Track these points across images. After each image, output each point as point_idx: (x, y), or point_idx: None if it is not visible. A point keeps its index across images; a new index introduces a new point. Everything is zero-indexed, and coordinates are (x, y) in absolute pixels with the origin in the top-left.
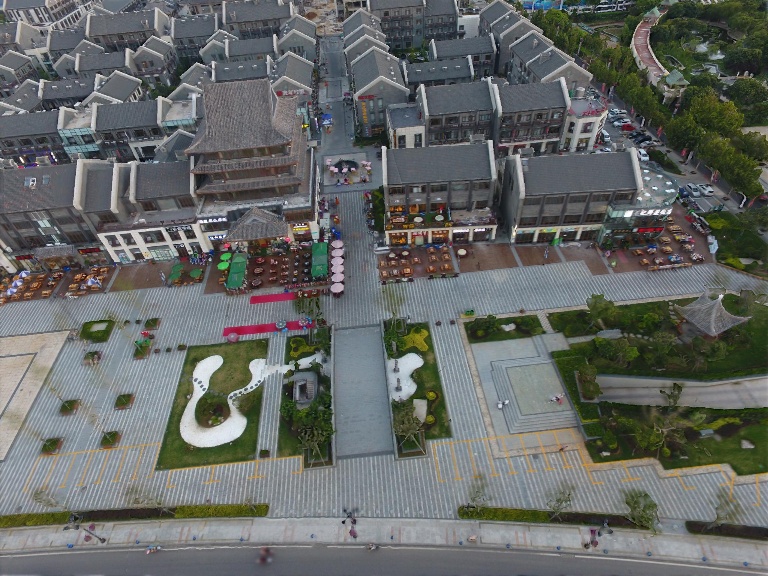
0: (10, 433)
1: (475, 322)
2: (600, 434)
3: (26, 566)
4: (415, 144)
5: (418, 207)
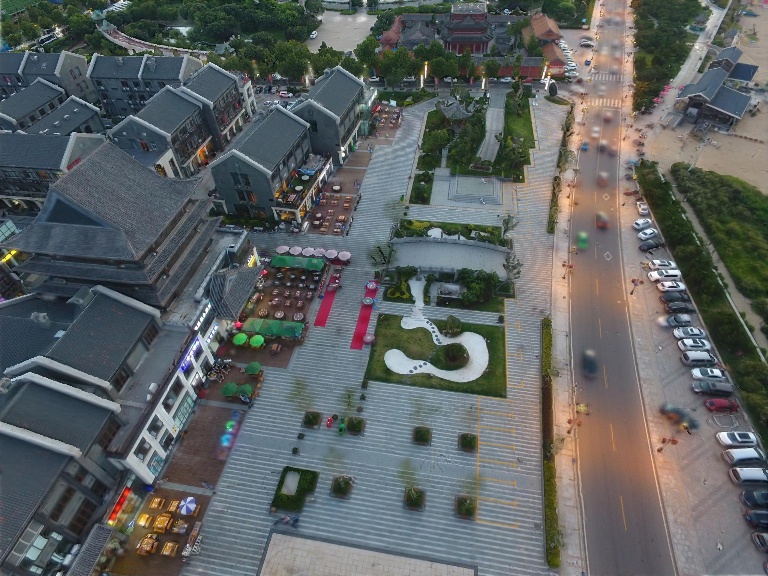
0: (436, 573)
1: (419, 192)
2: (511, 173)
3: (592, 500)
4: (173, 171)
5: (285, 183)
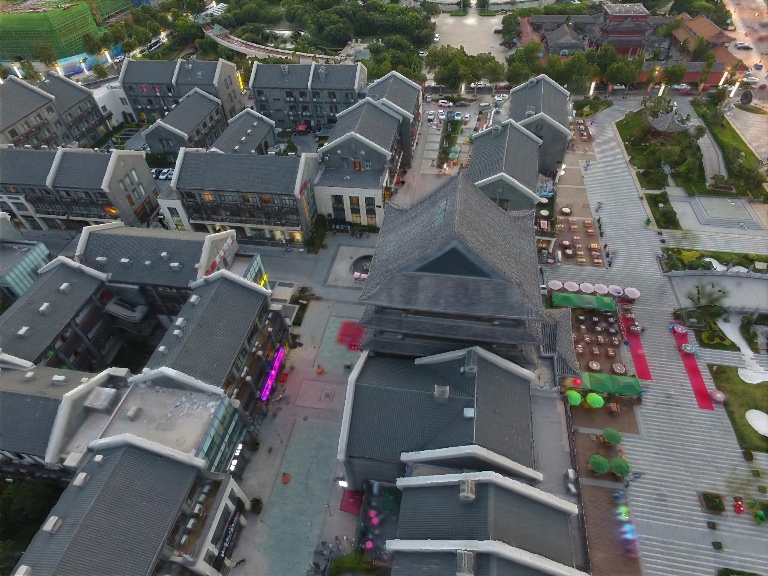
0: None
1: (672, 216)
2: (759, 193)
3: None
4: None
5: None
